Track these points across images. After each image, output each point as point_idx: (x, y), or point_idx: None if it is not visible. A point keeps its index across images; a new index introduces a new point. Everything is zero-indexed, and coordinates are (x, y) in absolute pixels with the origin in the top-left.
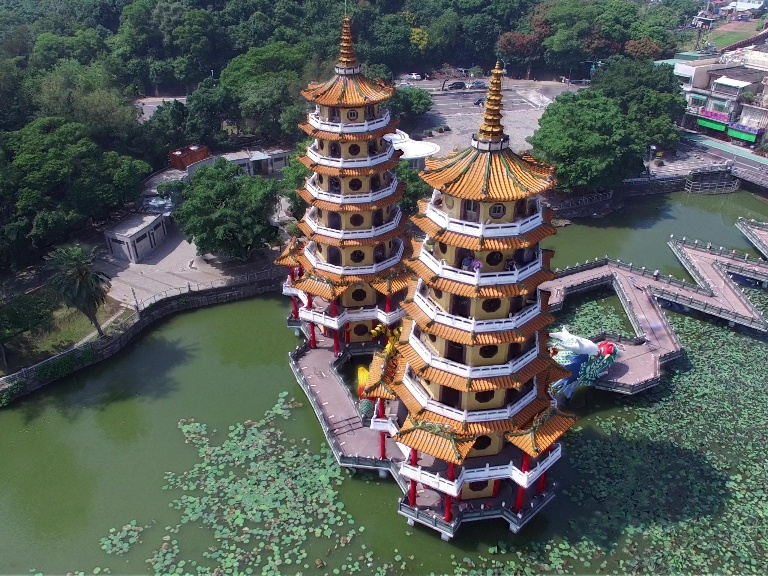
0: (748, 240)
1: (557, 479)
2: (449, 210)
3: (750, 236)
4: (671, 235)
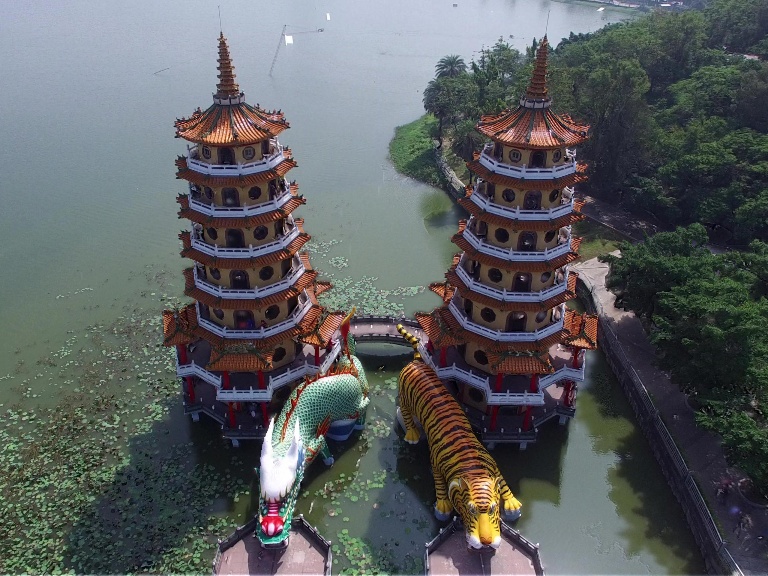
0: None
1: (206, 446)
2: None
3: None
4: None
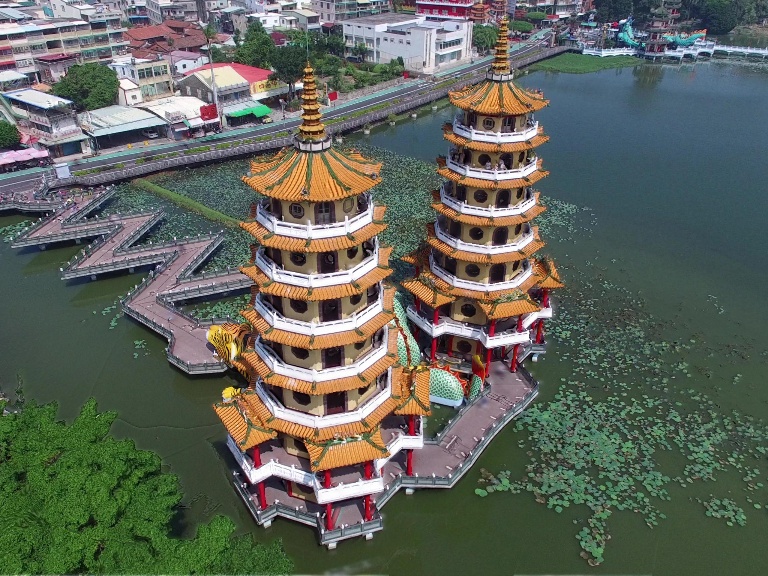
0: (34, 250)
1: None
2: (525, 127)
3: (48, 239)
4: (61, 270)
